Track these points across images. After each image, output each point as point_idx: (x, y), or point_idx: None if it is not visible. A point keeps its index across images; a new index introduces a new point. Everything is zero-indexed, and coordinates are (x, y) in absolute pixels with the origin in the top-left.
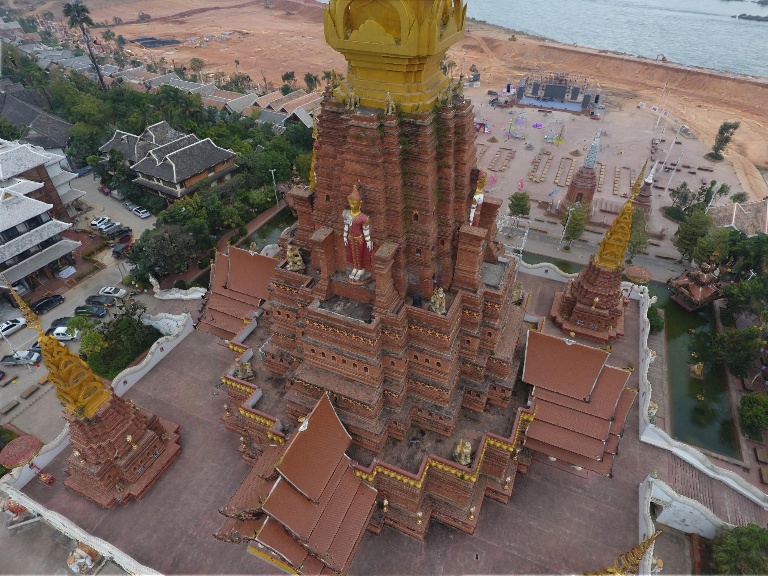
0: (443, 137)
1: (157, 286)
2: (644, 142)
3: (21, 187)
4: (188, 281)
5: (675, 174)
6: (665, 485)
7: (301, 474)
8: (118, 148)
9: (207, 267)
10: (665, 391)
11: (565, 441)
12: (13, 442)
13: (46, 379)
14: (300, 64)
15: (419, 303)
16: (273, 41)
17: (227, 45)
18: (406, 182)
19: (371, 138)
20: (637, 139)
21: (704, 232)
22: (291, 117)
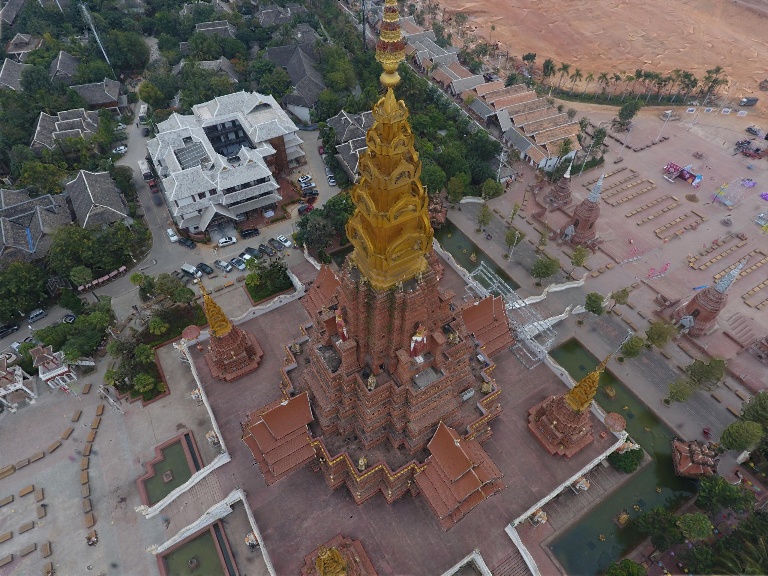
0: (394, 304)
1: (306, 250)
2: None
3: (263, 151)
4: (328, 252)
5: None
6: (481, 561)
7: (274, 424)
8: (337, 125)
9: (345, 246)
10: (578, 515)
11: (432, 495)
12: (190, 327)
13: (228, 285)
14: (566, 29)
15: (366, 375)
16: None
17: None
18: (369, 316)
19: (349, 291)
20: None
21: None
22: (493, 116)
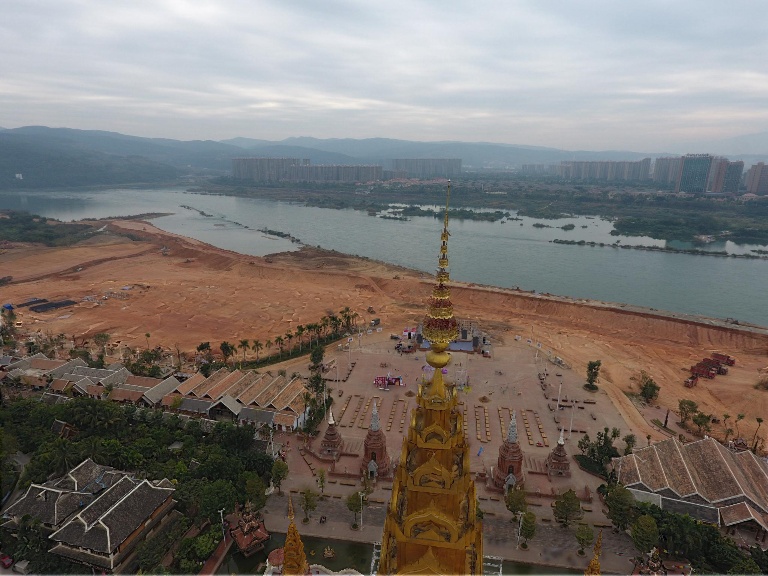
0: None
1: None
2: (533, 378)
3: None
4: None
5: (569, 411)
6: None
7: None
8: (32, 508)
9: None
10: None
11: None
12: None
13: None
14: (207, 319)
15: None
16: (176, 294)
17: (128, 302)
18: None
19: None
20: (527, 375)
21: (629, 508)
22: (217, 405)
